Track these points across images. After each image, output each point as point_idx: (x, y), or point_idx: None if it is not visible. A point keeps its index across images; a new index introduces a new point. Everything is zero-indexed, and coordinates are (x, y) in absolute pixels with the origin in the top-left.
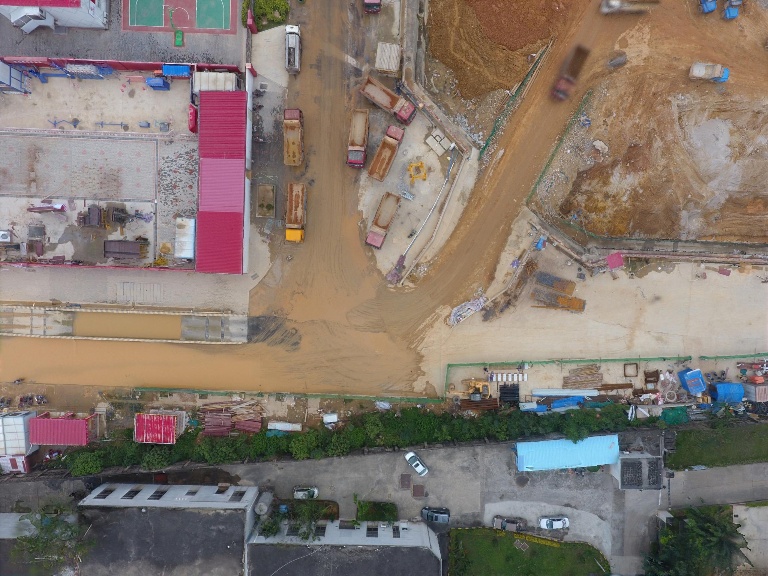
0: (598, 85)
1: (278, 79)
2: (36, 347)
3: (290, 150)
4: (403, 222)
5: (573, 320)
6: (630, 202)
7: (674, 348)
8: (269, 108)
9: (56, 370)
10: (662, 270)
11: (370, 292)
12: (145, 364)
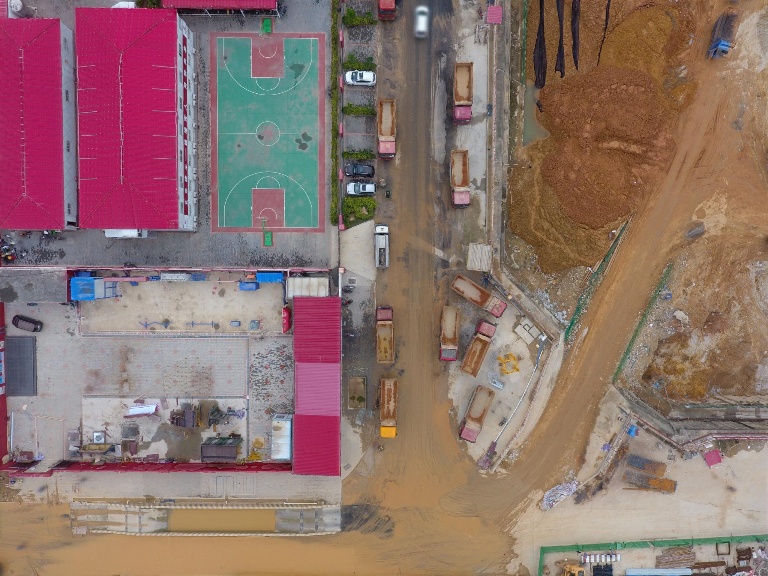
0: (678, 257)
1: (366, 273)
2: (131, 544)
3: (381, 346)
4: (494, 410)
5: (665, 501)
6: (708, 363)
7: (765, 525)
8: (358, 302)
9: (151, 565)
10: (751, 449)
11: (462, 478)
12: (239, 556)
